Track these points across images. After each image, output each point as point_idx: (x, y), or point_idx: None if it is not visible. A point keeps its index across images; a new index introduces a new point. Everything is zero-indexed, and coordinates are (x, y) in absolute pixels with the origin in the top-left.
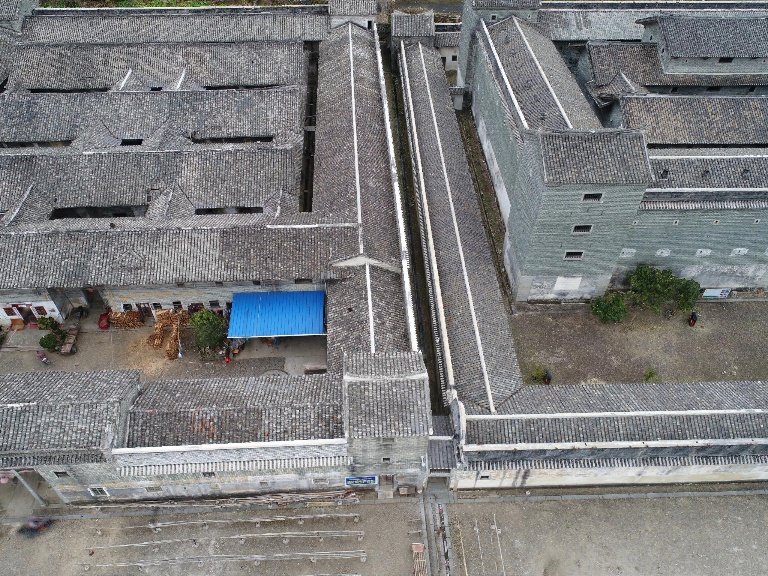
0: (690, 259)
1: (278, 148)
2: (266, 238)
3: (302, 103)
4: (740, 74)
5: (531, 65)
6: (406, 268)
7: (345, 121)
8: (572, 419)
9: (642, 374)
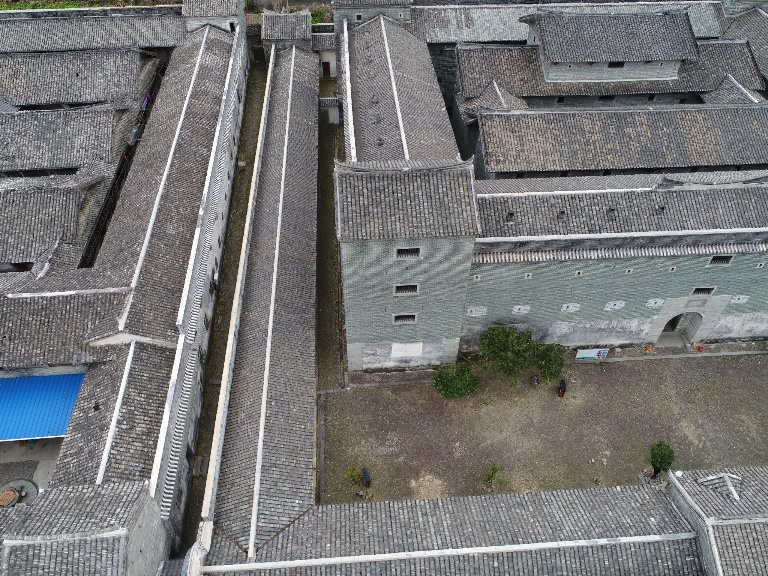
0: (556, 315)
1: (59, 187)
2: (6, 311)
3: (128, 124)
4: (635, 80)
5: (385, 75)
6: (180, 347)
7: (164, 147)
8: (353, 565)
9: (490, 467)
